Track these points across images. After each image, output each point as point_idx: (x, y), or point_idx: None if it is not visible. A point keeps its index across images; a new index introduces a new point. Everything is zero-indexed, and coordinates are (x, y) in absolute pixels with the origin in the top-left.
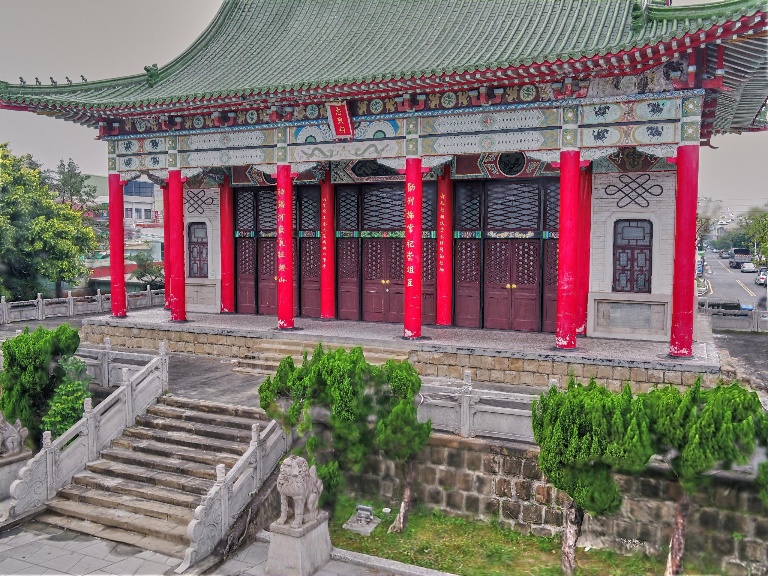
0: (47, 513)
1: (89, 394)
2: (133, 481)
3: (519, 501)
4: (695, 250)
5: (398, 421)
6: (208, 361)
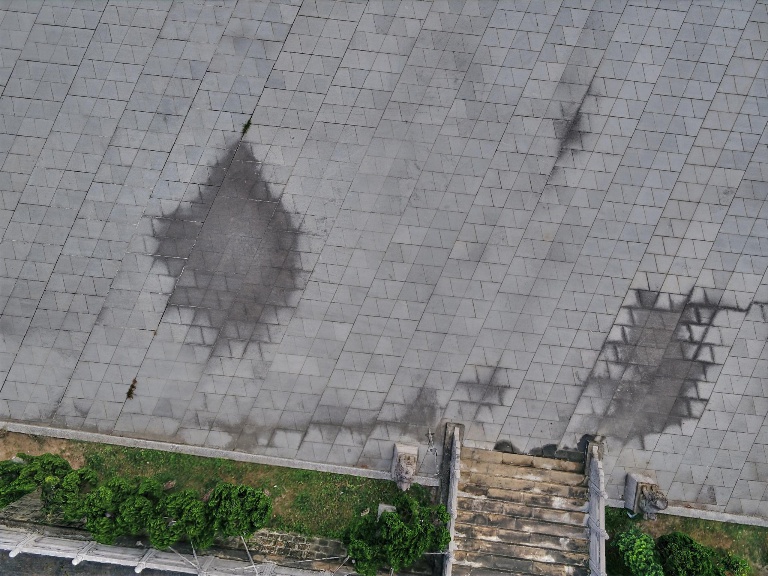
0: (582, 472)
1: (633, 568)
2: (545, 507)
3: (294, 542)
4: None
5: (357, 521)
6: None
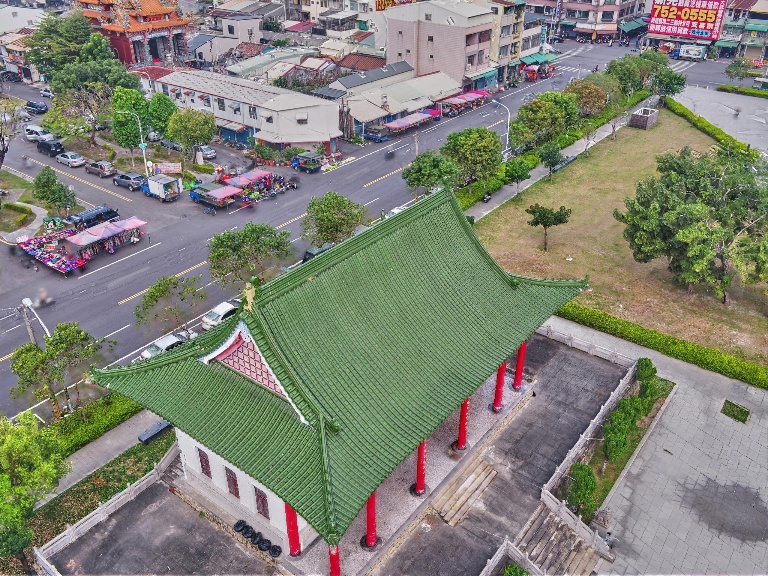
0: None
1: None
2: (557, 572)
3: None
4: (7, 150)
5: None
6: (425, 537)
